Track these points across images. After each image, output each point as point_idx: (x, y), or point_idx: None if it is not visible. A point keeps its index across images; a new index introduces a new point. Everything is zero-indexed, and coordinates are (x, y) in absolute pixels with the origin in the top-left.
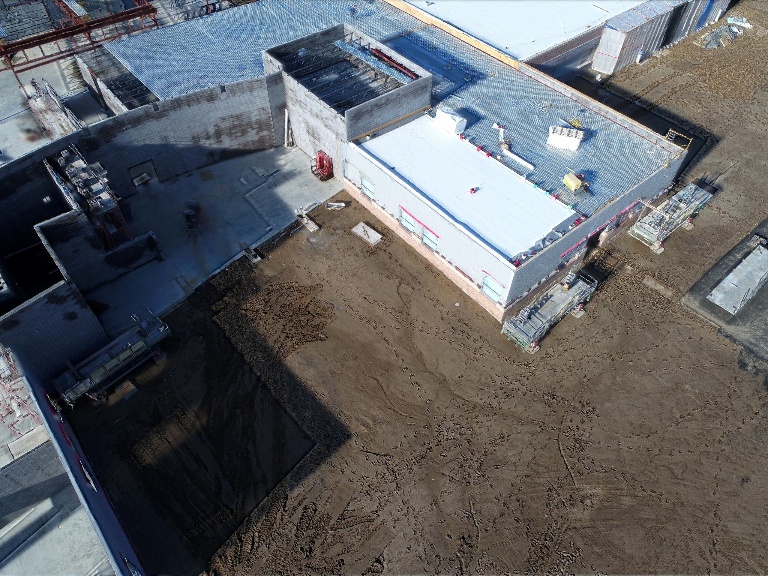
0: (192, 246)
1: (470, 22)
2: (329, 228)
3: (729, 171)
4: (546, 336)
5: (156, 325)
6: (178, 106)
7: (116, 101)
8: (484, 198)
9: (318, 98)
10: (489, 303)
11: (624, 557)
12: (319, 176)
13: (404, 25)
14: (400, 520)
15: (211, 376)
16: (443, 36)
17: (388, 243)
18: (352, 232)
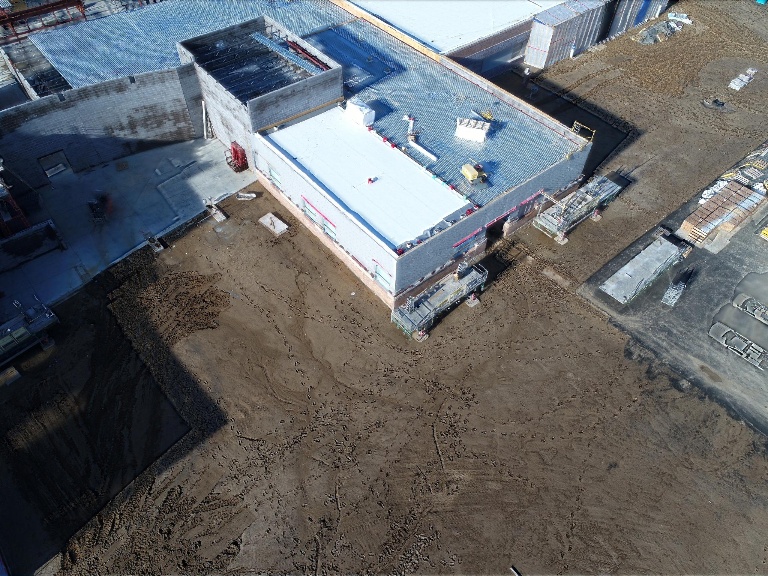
0: (97, 235)
1: (400, 16)
2: (237, 218)
3: (646, 164)
4: (437, 325)
5: None
6: (86, 96)
7: (32, 92)
8: (381, 188)
9: (225, 89)
10: (382, 292)
11: (481, 540)
12: (234, 167)
13: (334, 19)
14: (263, 503)
15: (96, 362)
16: (371, 29)
17: (293, 233)
18: (259, 222)
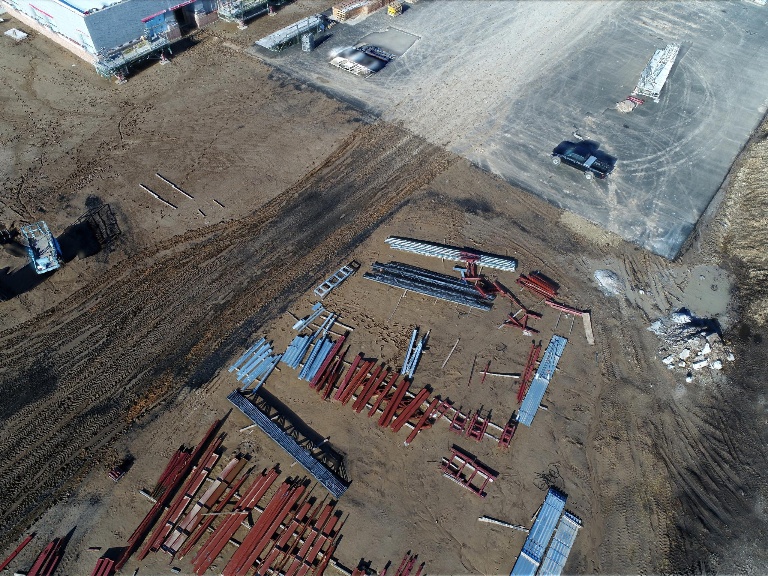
0: None
1: None
2: None
3: None
4: (135, 75)
5: None
6: None
7: None
8: None
9: None
10: (92, 58)
11: (139, 166)
12: None
13: None
14: None
15: None
16: None
17: (32, 39)
18: (4, 35)
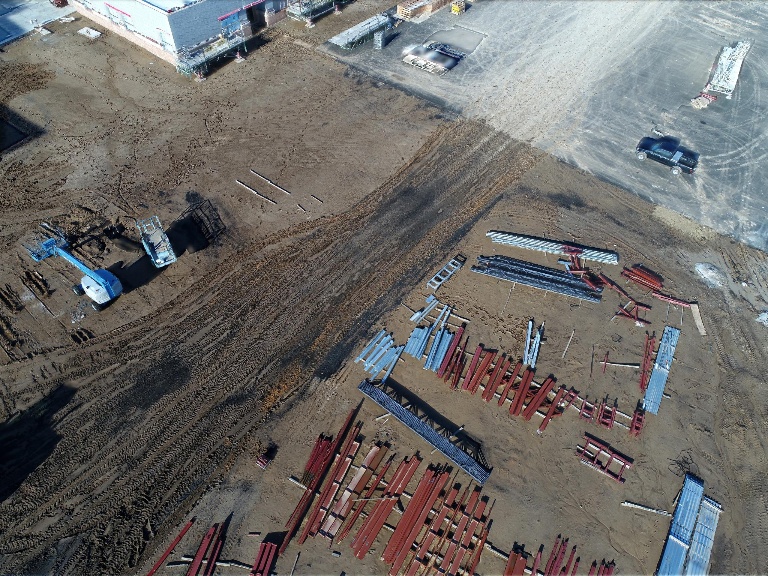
0: None
1: None
2: (60, 33)
3: None
4: (213, 73)
5: None
6: None
7: None
8: None
9: None
10: (170, 56)
11: (232, 162)
12: (56, 4)
13: None
14: (83, 162)
15: None
16: None
17: (106, 37)
18: (78, 33)
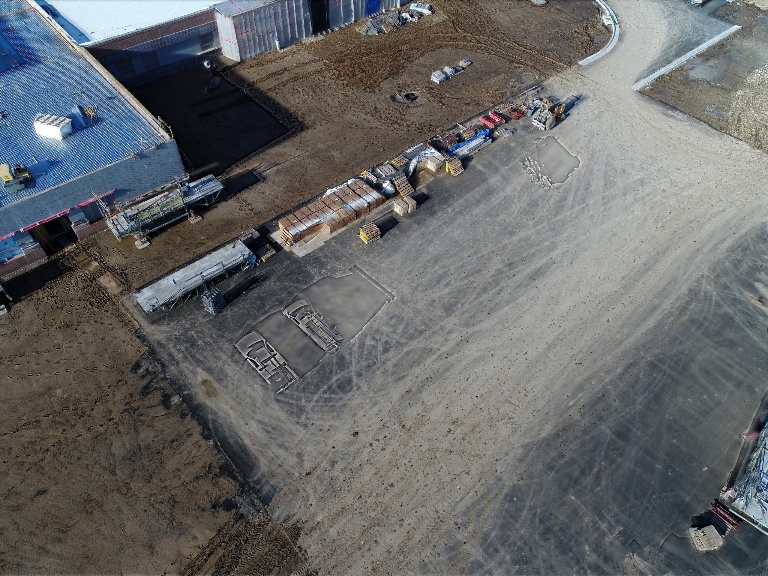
0: None
1: (76, 6)
2: None
3: (289, 161)
4: None
5: None
6: None
7: None
8: None
9: None
10: None
11: None
12: None
13: (7, 9)
14: None
15: None
16: (35, 20)
17: None
18: None
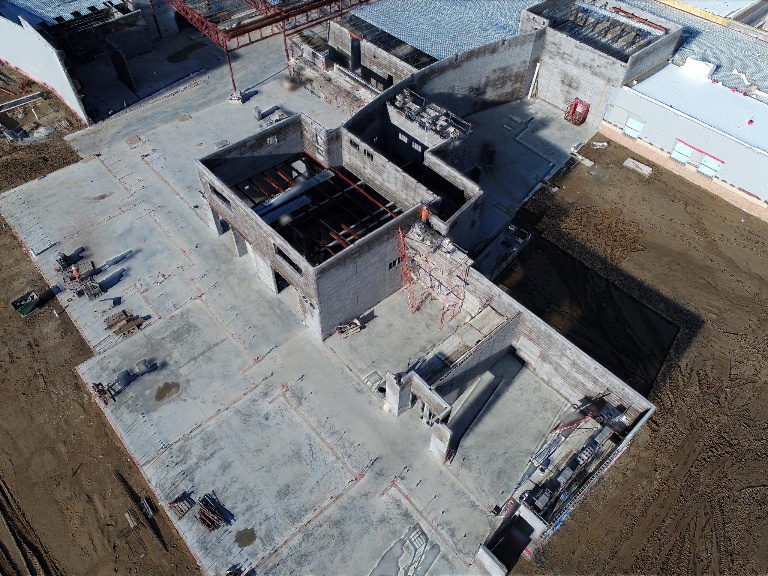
0: (493, 180)
1: None
2: (602, 163)
3: None
4: None
5: (513, 238)
6: (470, 57)
7: (390, 58)
8: (762, 128)
9: (593, 48)
10: None
11: None
12: (573, 121)
13: None
14: None
15: (566, 279)
16: None
17: (659, 174)
18: (624, 166)
